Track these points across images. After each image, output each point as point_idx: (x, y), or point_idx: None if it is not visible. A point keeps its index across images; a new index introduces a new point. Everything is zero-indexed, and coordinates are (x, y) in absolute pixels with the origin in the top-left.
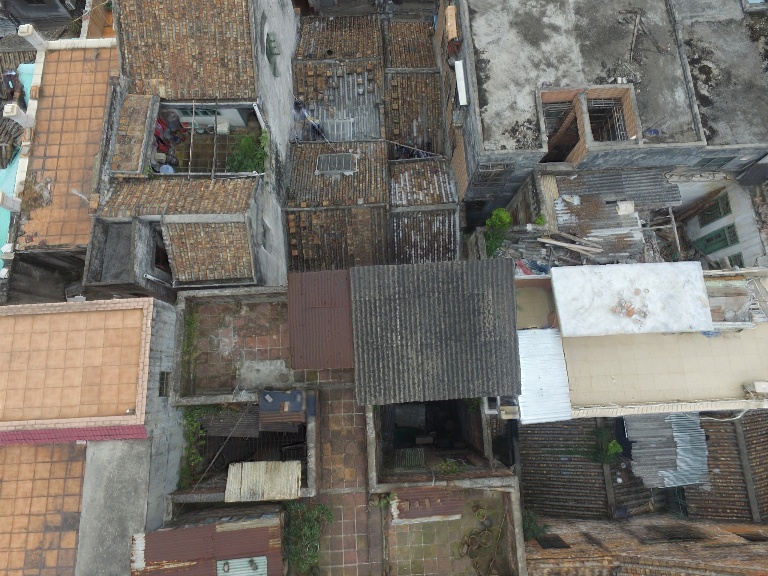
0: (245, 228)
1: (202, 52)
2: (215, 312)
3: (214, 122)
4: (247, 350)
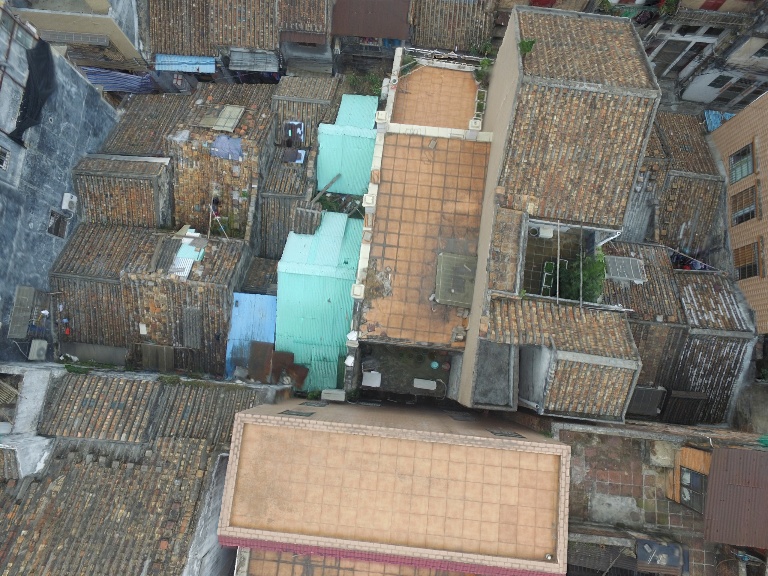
0: (632, 374)
1: (582, 177)
2: (567, 439)
3: (540, 226)
4: (599, 482)
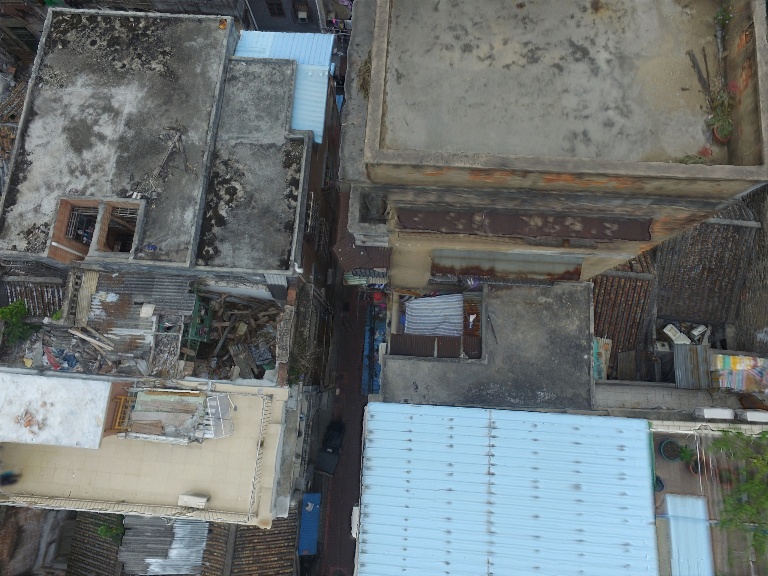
0: None
1: None
2: None
3: None
4: None
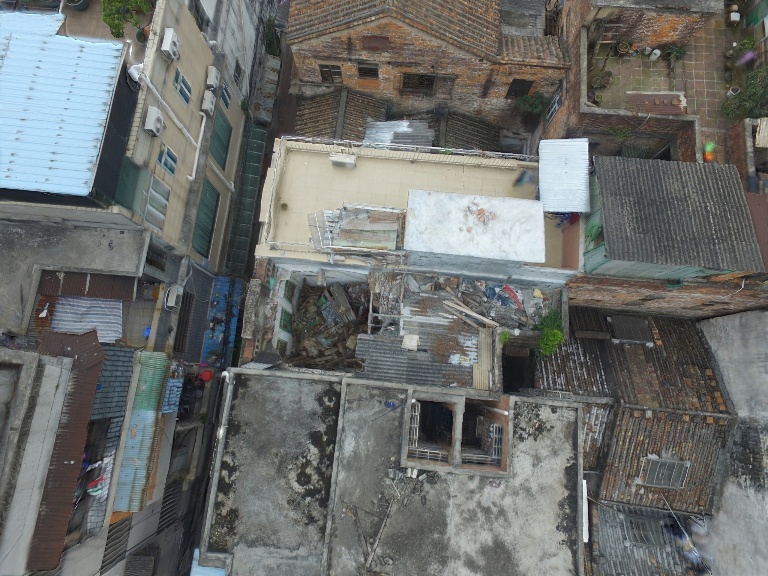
0: None
1: None
2: None
3: None
4: None
